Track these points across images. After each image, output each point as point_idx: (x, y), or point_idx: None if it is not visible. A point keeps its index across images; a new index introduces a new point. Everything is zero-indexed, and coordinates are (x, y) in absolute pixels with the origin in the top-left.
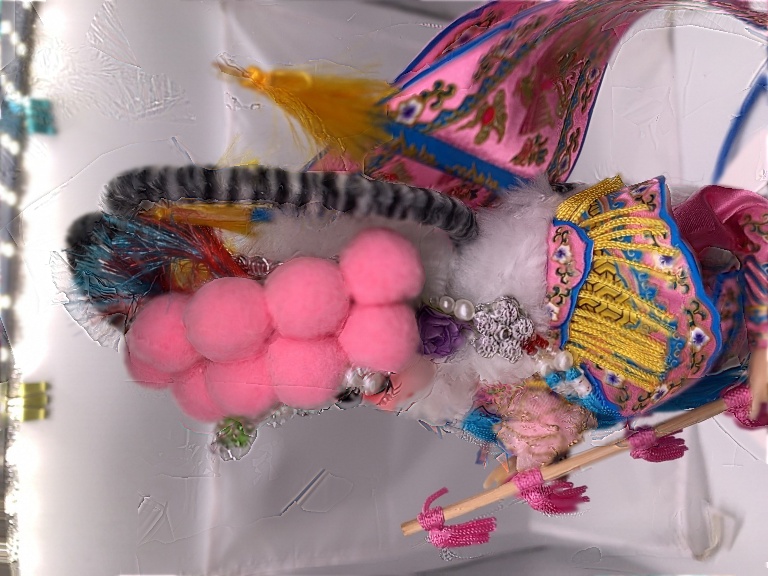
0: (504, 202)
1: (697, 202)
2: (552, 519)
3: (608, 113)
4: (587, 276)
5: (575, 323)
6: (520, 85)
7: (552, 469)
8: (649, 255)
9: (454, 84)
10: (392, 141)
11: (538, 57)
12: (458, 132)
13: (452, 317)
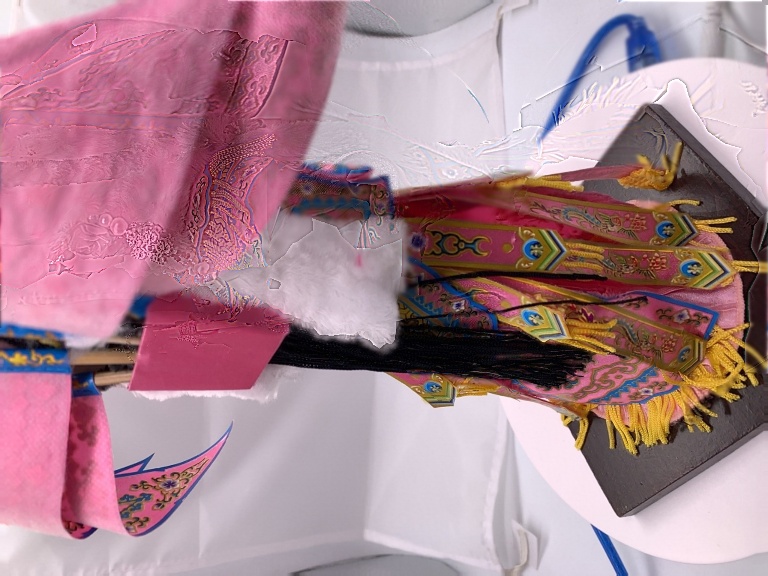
0: (175, 139)
1: (334, 168)
2: None
3: (303, 60)
4: (208, 223)
5: (206, 248)
6: (162, 64)
7: (204, 326)
8: (239, 225)
9: (61, 88)
10: (18, 121)
11: (178, 43)
12: (91, 108)
13: (108, 231)
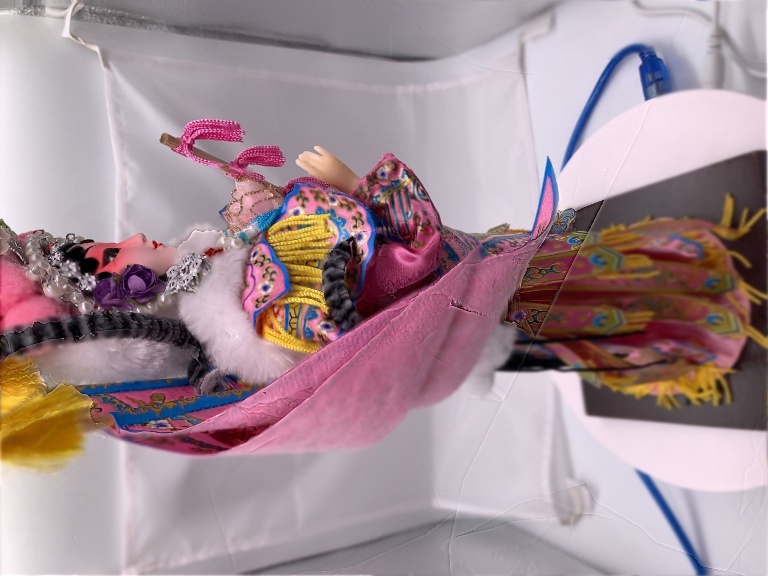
0: None
1: None
2: None
3: None
4: None
5: None
6: None
7: None
8: None
9: None
10: None
11: None
12: None
13: None
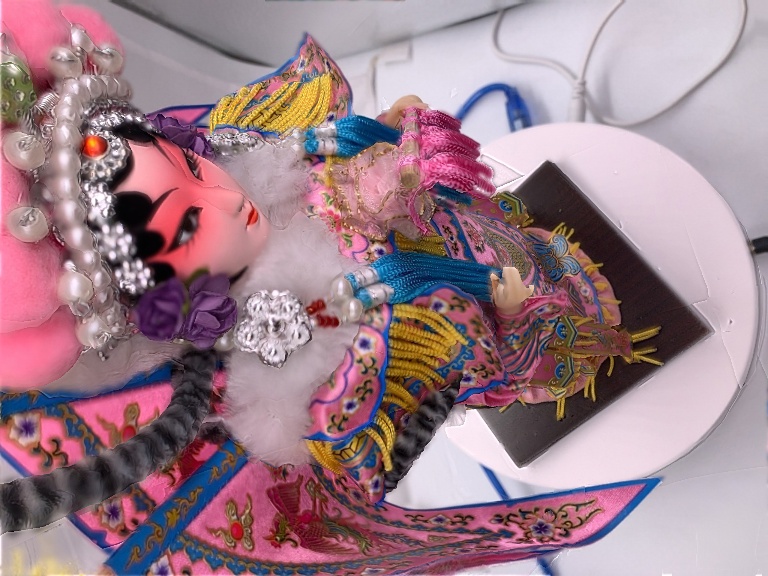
0: None
1: None
2: (448, 132)
3: None
4: None
5: None
6: None
7: None
8: None
9: None
10: None
11: None
12: None
13: None
